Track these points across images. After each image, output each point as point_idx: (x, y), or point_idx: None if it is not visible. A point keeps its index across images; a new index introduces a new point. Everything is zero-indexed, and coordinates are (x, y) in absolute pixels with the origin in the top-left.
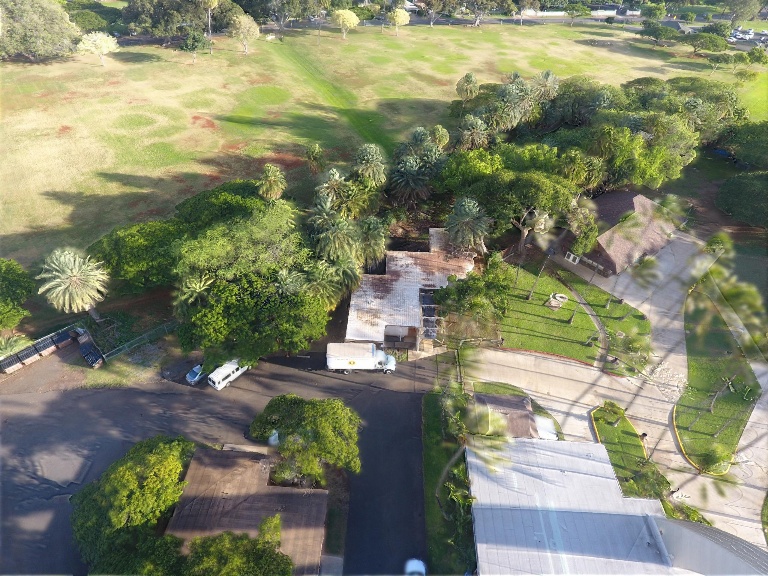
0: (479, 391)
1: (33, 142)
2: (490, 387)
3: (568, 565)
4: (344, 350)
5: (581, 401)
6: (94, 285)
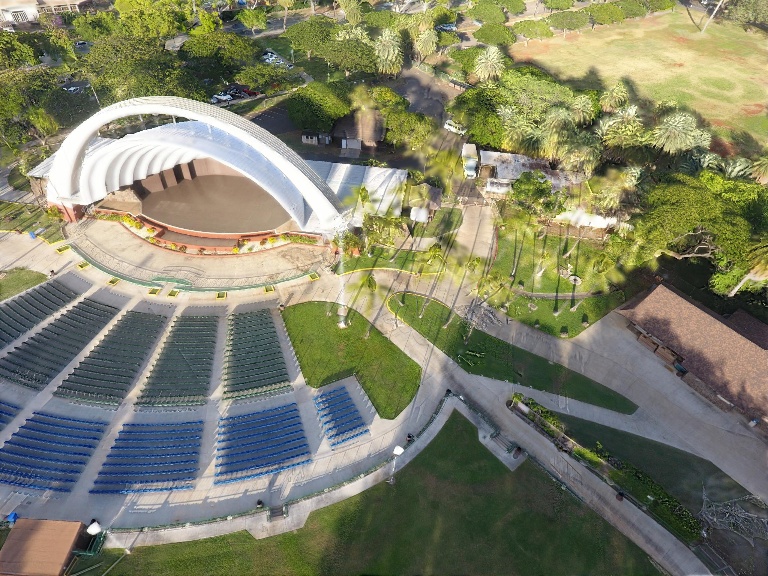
0: (454, 209)
1: (649, 59)
2: (458, 214)
3: (335, 185)
4: (470, 148)
5: (450, 255)
6: (491, 71)
